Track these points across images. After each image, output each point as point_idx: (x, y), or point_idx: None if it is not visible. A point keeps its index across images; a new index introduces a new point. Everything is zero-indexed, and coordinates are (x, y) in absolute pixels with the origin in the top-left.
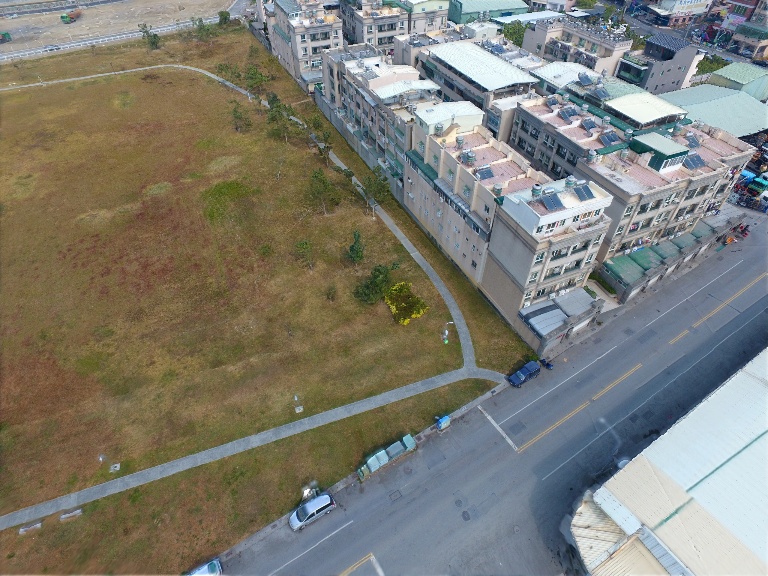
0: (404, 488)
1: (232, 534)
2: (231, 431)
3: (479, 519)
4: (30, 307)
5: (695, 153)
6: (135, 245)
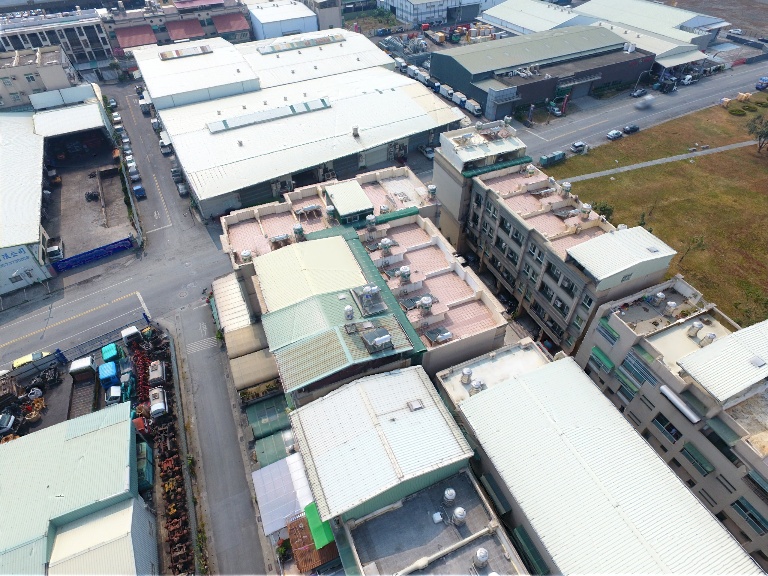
0: (540, 154)
1: None
2: (645, 172)
3: None
4: None
5: (302, 210)
6: None
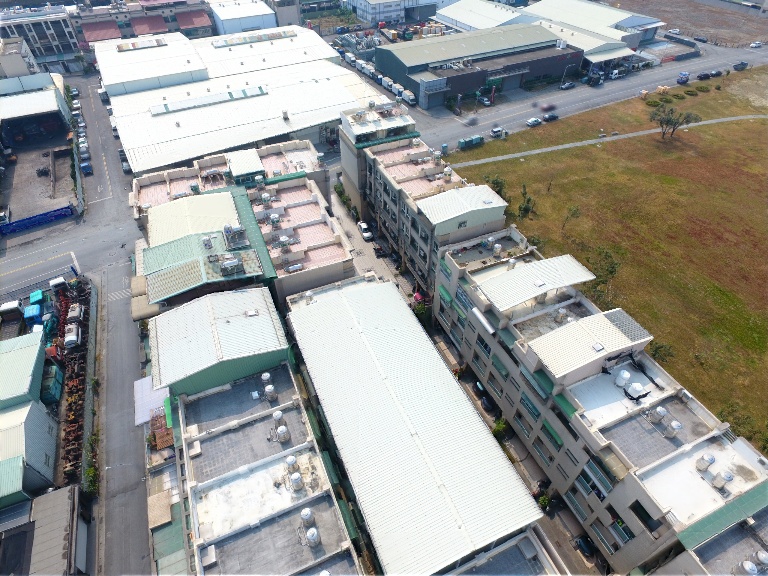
0: None
1: (530, 131)
2: (554, 154)
3: (429, 133)
4: (766, 207)
5: (206, 174)
6: (760, 257)
